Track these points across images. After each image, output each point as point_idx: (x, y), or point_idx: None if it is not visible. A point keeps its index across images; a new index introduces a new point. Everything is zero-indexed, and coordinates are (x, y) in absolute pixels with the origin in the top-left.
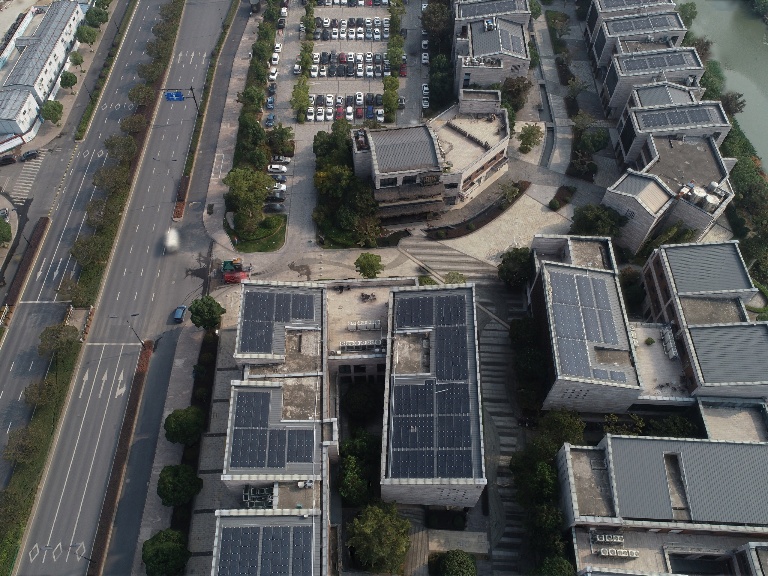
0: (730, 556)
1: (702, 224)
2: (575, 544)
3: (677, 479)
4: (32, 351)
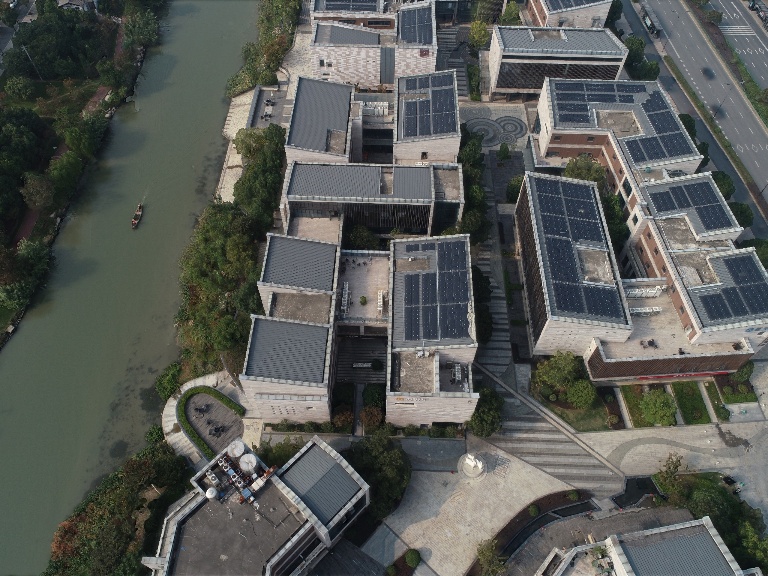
0: None
1: None
2: None
3: (384, 187)
4: None
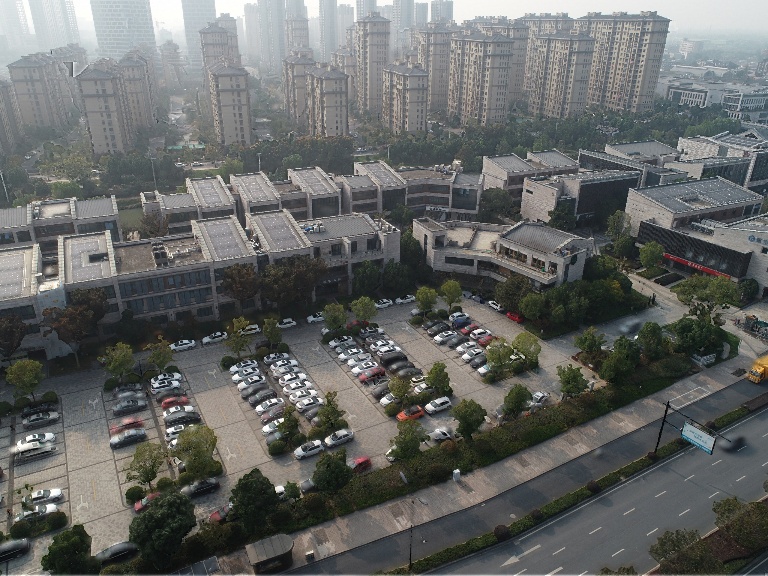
0: None
1: None
2: None
3: None
4: None
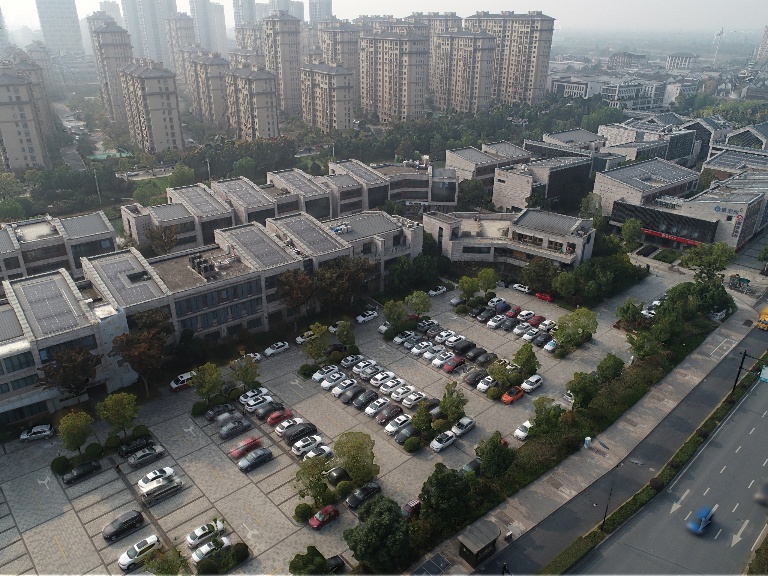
0: None
1: None
2: None
3: None
4: None
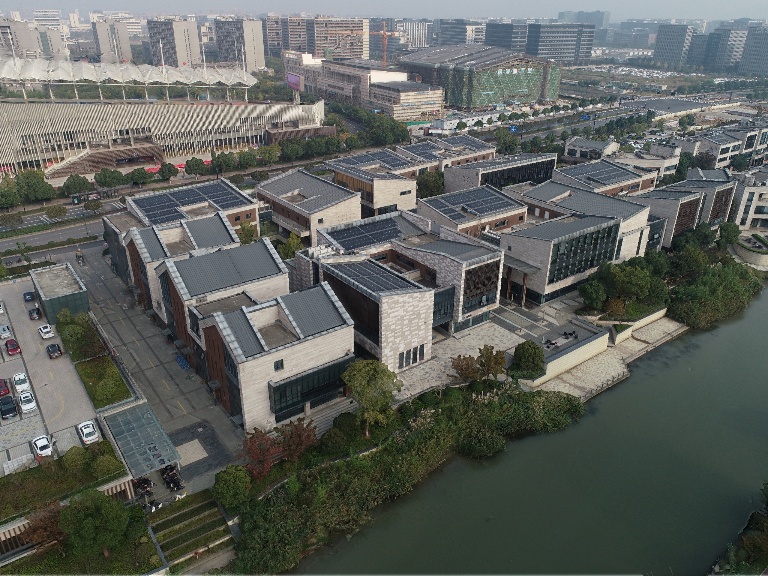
0: None
1: (741, 195)
2: None
3: None
4: None
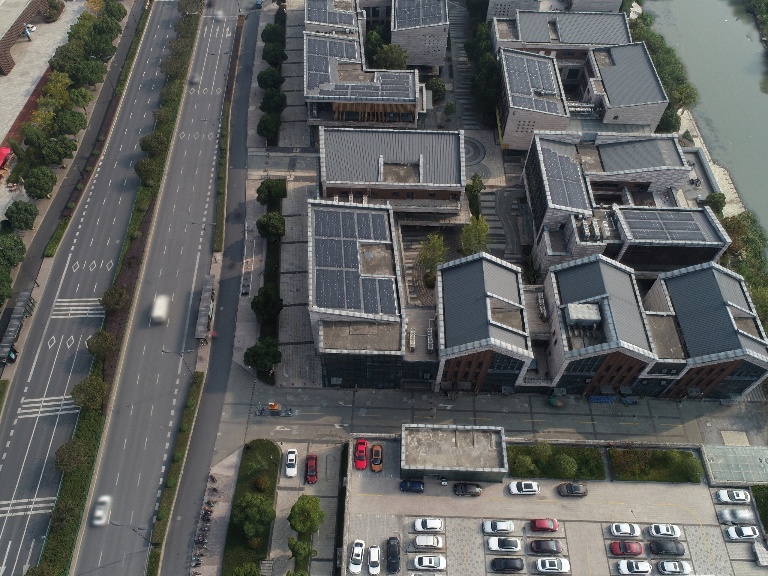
0: (583, 68)
1: None
2: (498, 57)
3: (555, 30)
4: (170, 19)
